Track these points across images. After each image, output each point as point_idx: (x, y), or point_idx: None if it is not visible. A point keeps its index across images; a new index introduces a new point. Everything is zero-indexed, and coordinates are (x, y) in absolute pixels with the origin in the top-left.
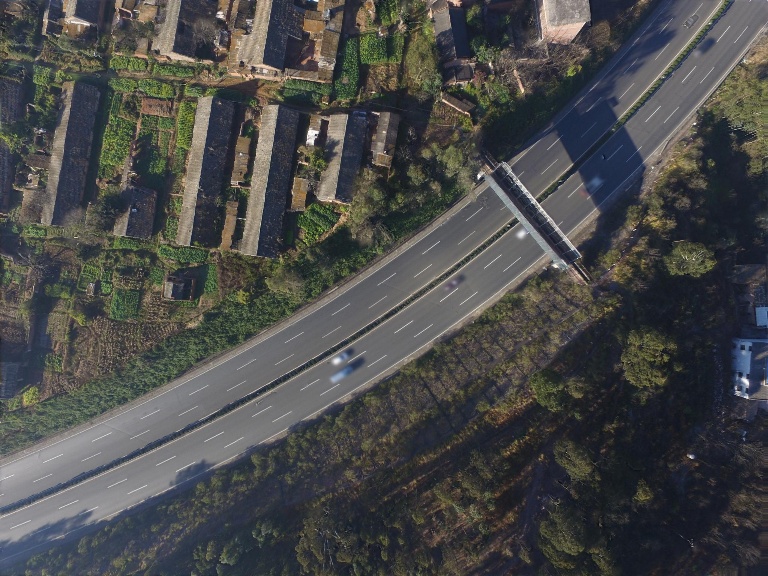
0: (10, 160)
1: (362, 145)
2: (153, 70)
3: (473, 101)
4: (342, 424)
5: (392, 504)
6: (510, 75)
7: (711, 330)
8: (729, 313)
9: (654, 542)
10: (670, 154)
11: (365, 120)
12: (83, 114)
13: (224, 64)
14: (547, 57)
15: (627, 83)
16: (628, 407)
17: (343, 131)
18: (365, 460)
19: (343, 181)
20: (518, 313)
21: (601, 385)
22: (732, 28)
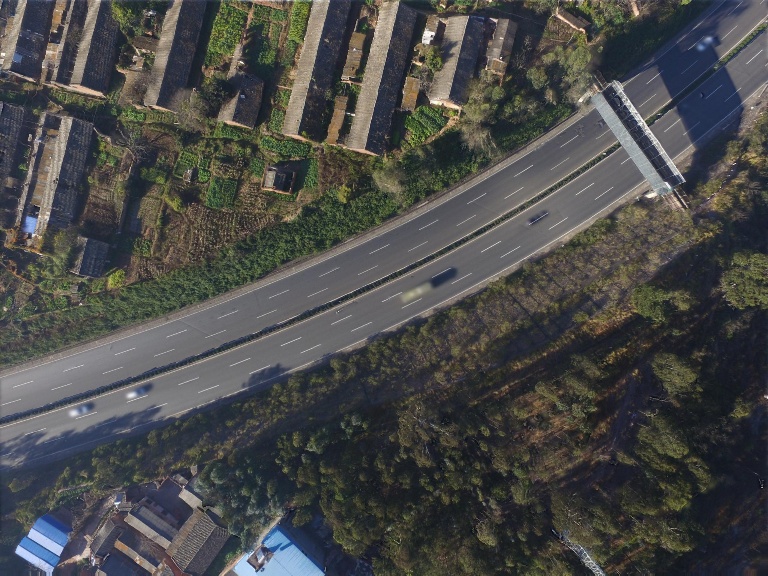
0: (116, 40)
1: (478, 50)
2: None
3: (587, 20)
4: (427, 334)
5: (483, 407)
6: None
7: None
8: None
9: (729, 477)
10: None
11: (483, 25)
12: None
13: None
14: None
15: (730, 25)
16: (715, 338)
17: (462, 32)
18: (454, 365)
19: (457, 82)
20: (612, 237)
21: (695, 310)
22: None
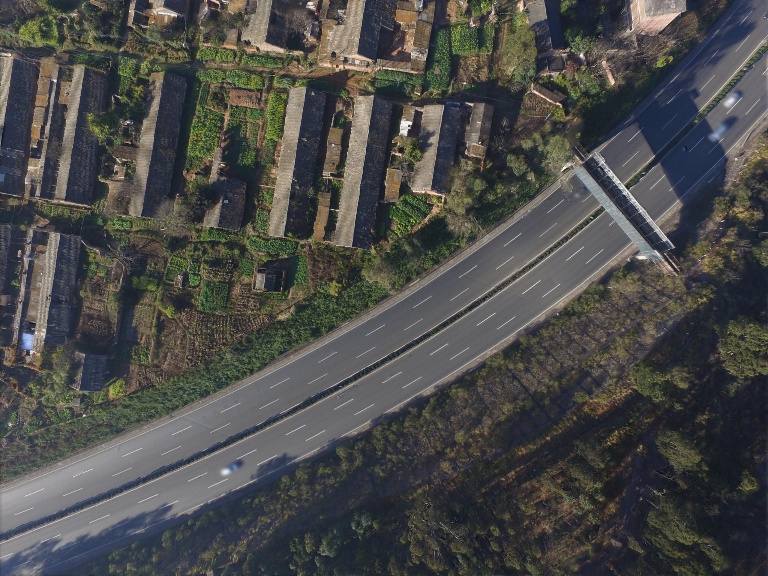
0: (95, 152)
1: (456, 136)
2: (241, 61)
3: (563, 92)
4: (429, 416)
5: (491, 495)
6: (599, 66)
7: None
8: None
9: (742, 533)
10: (753, 146)
11: (459, 111)
12: (172, 105)
13: (313, 55)
14: (636, 48)
15: (708, 75)
16: (718, 398)
17: (439, 122)
18: (459, 452)
19: (438, 172)
20: (606, 305)
21: (695, 376)
22: None
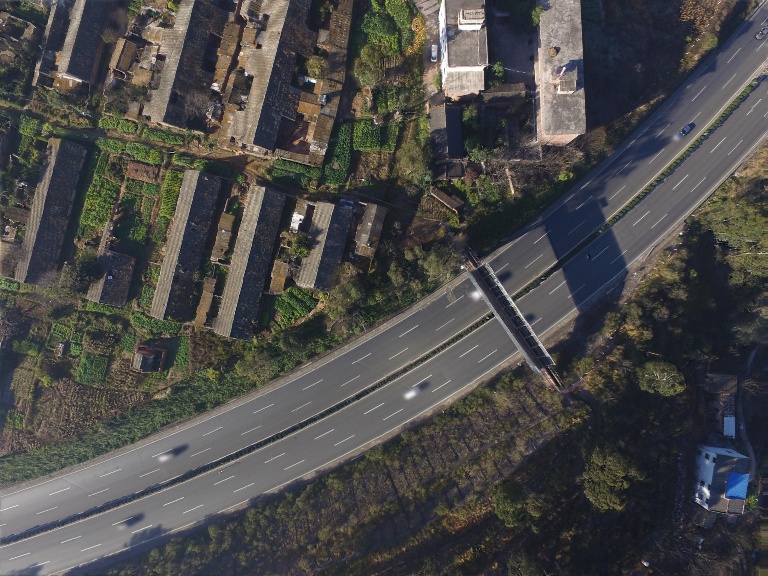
0: None
1: (346, 235)
2: (142, 134)
3: (462, 197)
4: (302, 505)
5: None
6: (502, 174)
7: (678, 438)
8: (697, 422)
9: None
10: (654, 262)
11: (351, 210)
12: (67, 173)
13: (215, 136)
14: (540, 159)
15: (619, 185)
16: (587, 514)
17: (328, 220)
18: (321, 549)
19: (323, 270)
20: (488, 410)
21: (562, 494)
22: (727, 140)
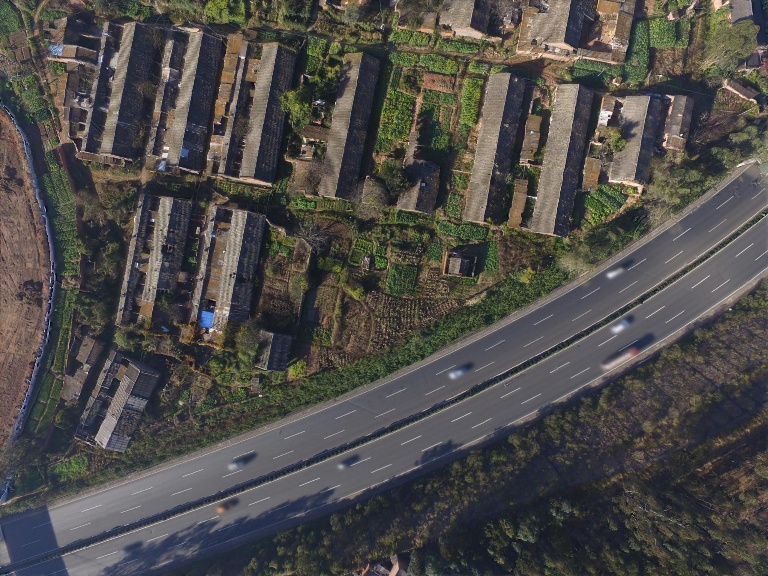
0: (283, 130)
1: (657, 127)
2: (435, 45)
3: (754, 89)
4: (607, 406)
5: None
6: None
7: None
8: None
9: None
10: None
11: None
12: (367, 86)
13: (510, 42)
14: None
15: None
16: None
17: (644, 112)
18: (648, 442)
19: (641, 162)
20: None
21: None
22: None
